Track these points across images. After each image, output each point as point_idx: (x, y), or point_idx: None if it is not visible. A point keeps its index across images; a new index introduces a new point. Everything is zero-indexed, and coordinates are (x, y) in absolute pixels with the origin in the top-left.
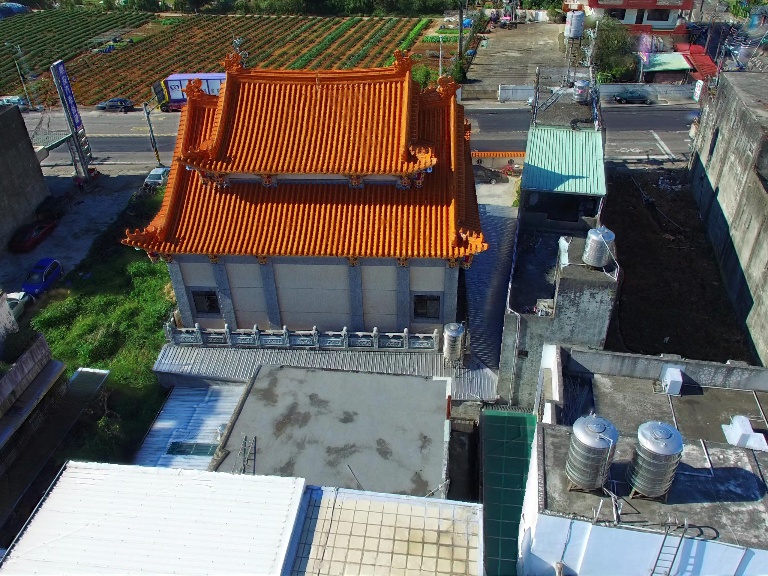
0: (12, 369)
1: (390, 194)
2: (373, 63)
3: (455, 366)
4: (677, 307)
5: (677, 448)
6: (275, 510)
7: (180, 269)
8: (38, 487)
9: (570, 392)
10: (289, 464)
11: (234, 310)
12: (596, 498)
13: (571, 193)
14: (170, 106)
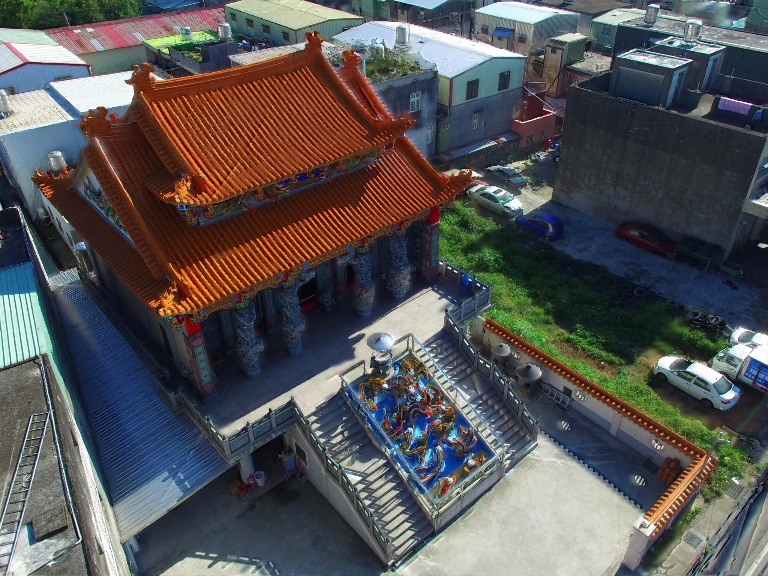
0: None
1: None
2: None
3: None
4: None
5: None
6: None
7: None
8: None
9: None
10: None
11: None
12: None
13: None
14: None
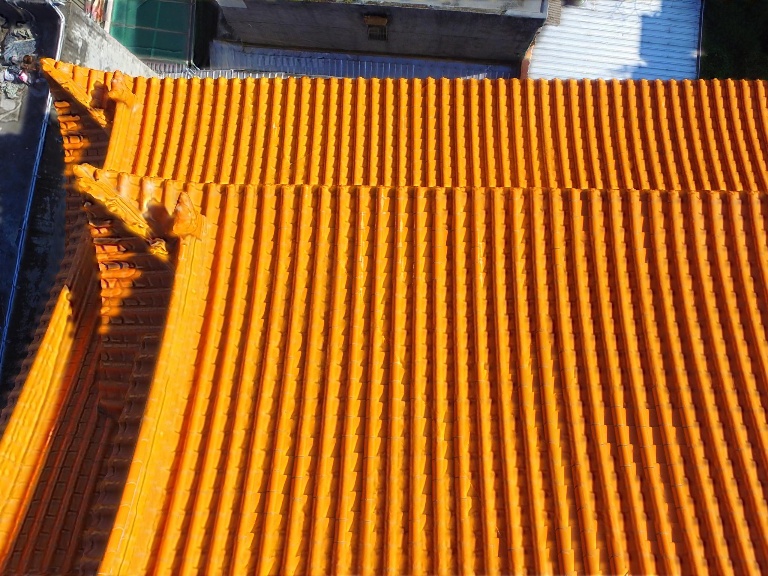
0: None
1: None
2: None
3: None
4: None
5: None
6: None
7: None
8: None
9: None
10: None
11: None
12: None
13: None
14: None
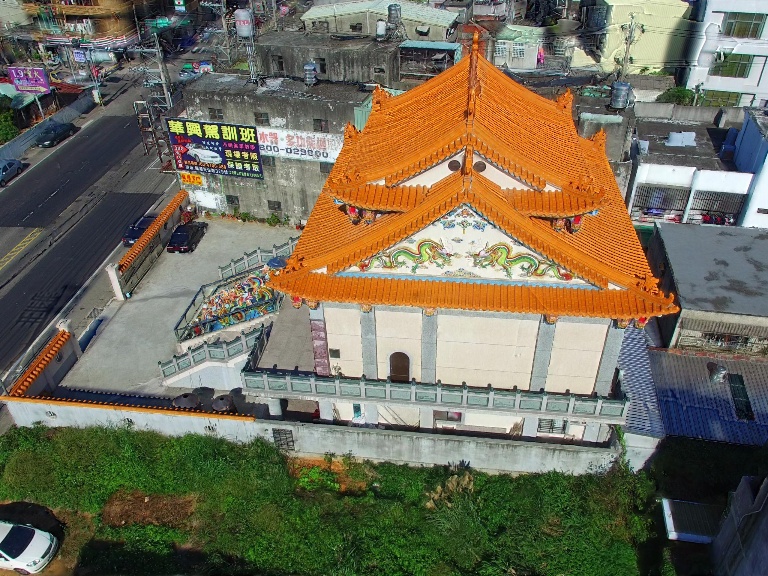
0: None
1: None
2: None
3: None
4: None
5: None
6: None
7: None
8: None
9: None
10: None
11: None
12: None
13: None
14: None
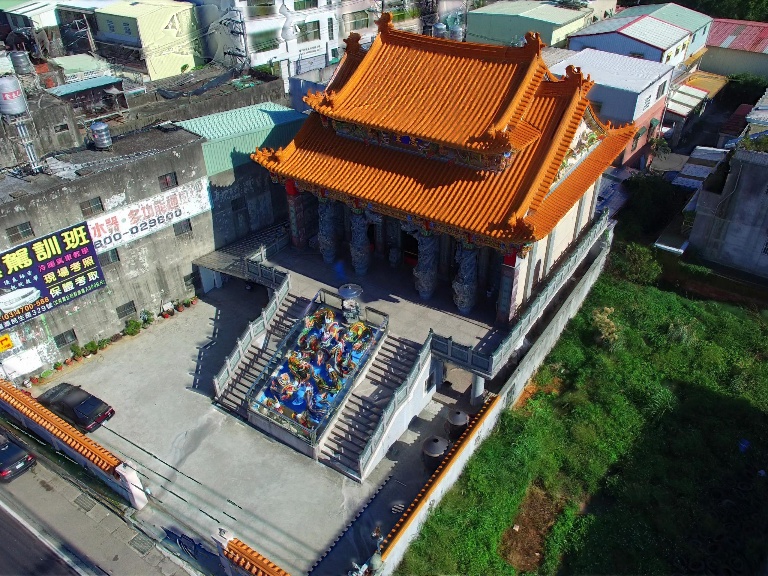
0: None
1: None
2: None
3: None
4: None
5: None
6: None
7: None
8: None
9: None
10: None
11: None
12: None
13: None
14: None
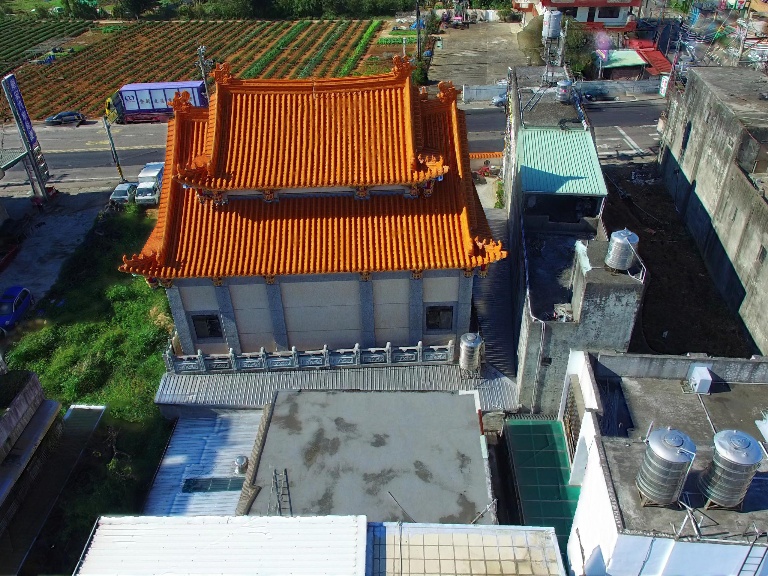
0: (6, 414)
1: (398, 204)
2: (331, 67)
3: (472, 377)
4: (670, 301)
5: (757, 456)
6: (341, 554)
7: (180, 294)
8: (44, 541)
9: (602, 398)
10: (326, 496)
11: (238, 333)
12: (671, 512)
13: (573, 194)
14: (125, 118)
